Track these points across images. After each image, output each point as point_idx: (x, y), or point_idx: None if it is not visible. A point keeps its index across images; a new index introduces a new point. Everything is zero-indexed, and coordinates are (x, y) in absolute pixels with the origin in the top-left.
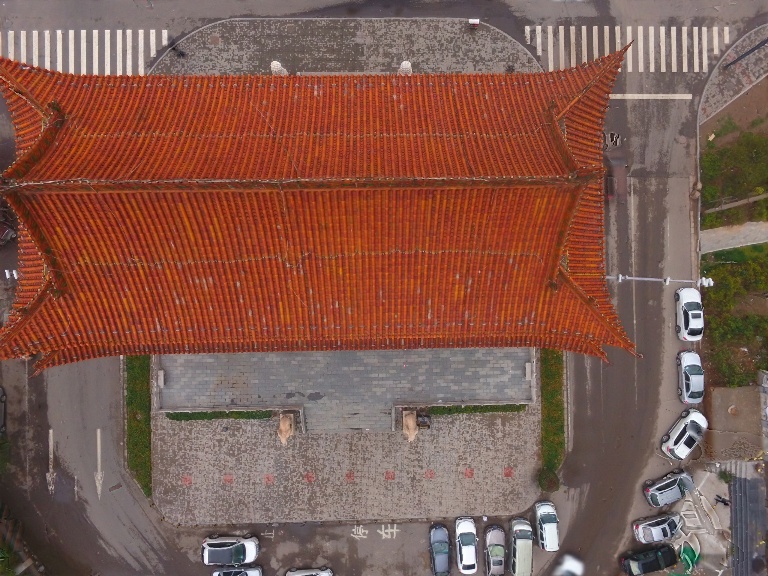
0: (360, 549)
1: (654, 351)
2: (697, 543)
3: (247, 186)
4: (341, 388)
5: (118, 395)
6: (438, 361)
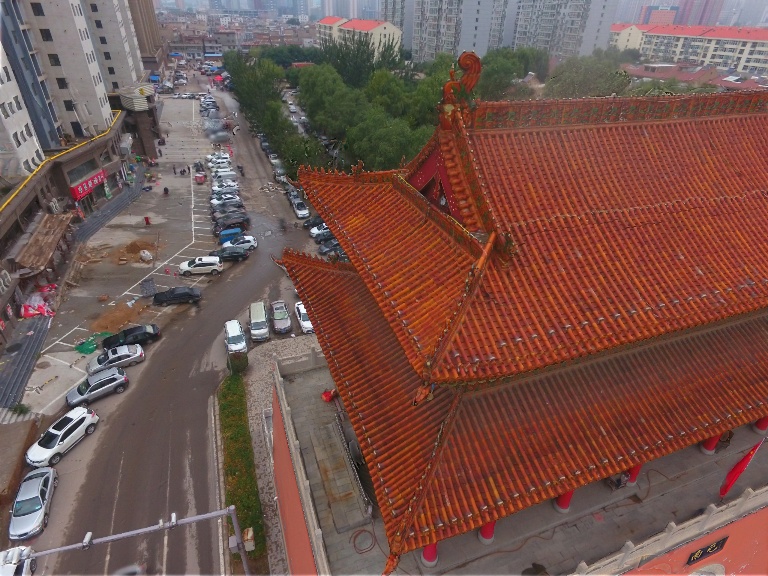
0: None
1: (82, 526)
2: None
3: None
4: None
5: None
6: None
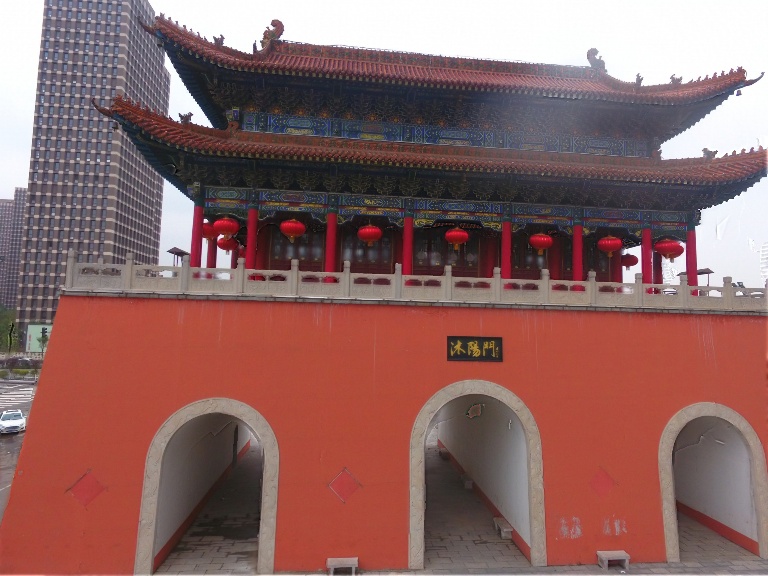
0: None
1: None
2: None
3: (411, 59)
4: None
5: None
6: None
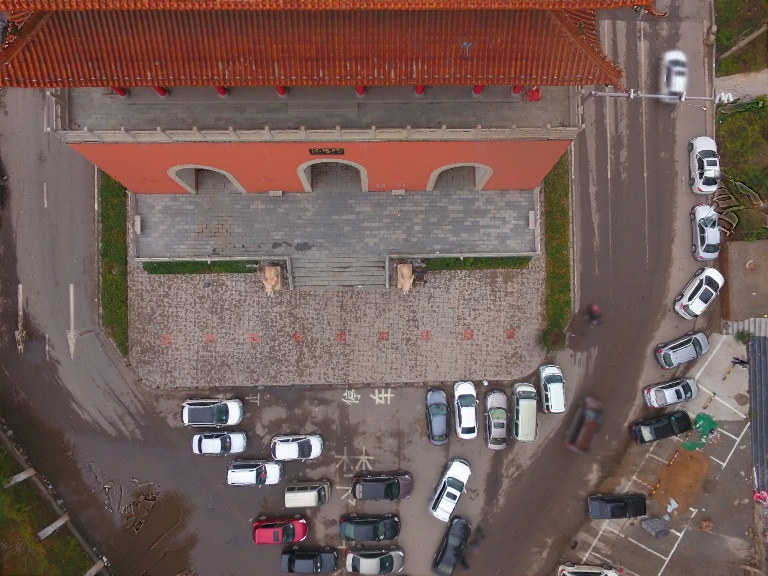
0: (352, 415)
1: (666, 206)
2: (734, 216)
3: None
4: (331, 238)
5: (92, 248)
6: (435, 210)
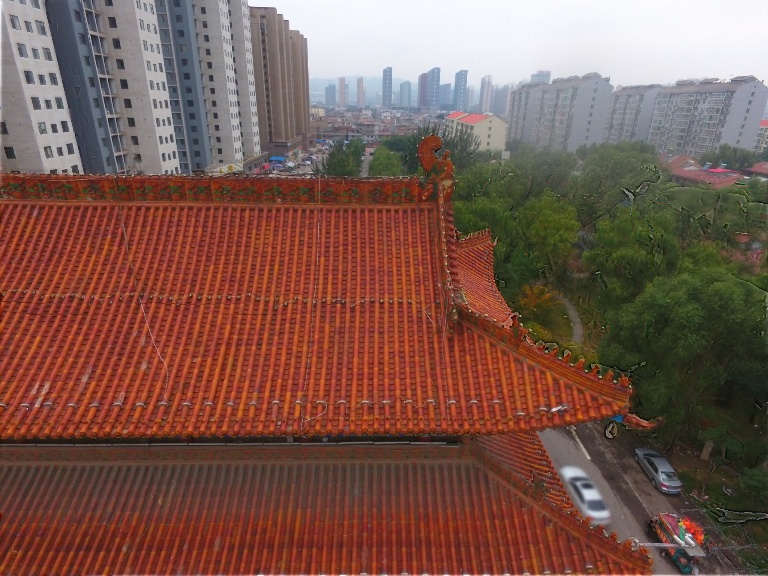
0: None
1: None
2: None
3: None
4: None
5: None
6: None
